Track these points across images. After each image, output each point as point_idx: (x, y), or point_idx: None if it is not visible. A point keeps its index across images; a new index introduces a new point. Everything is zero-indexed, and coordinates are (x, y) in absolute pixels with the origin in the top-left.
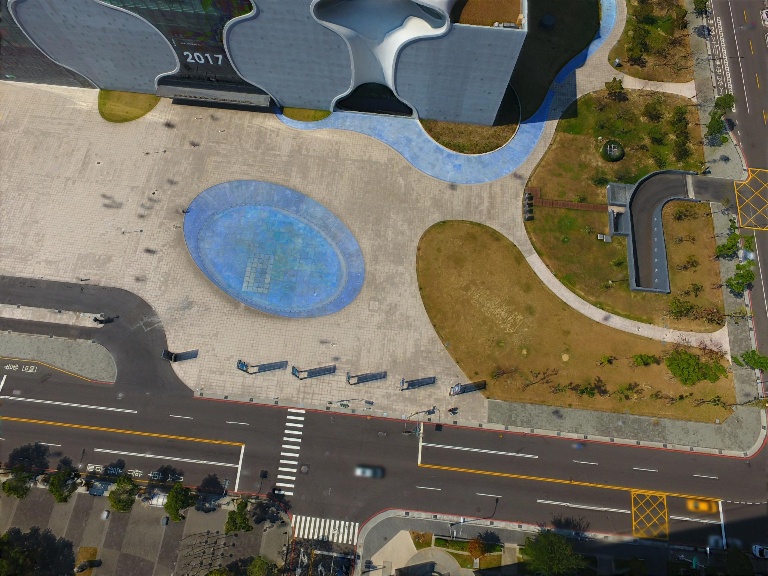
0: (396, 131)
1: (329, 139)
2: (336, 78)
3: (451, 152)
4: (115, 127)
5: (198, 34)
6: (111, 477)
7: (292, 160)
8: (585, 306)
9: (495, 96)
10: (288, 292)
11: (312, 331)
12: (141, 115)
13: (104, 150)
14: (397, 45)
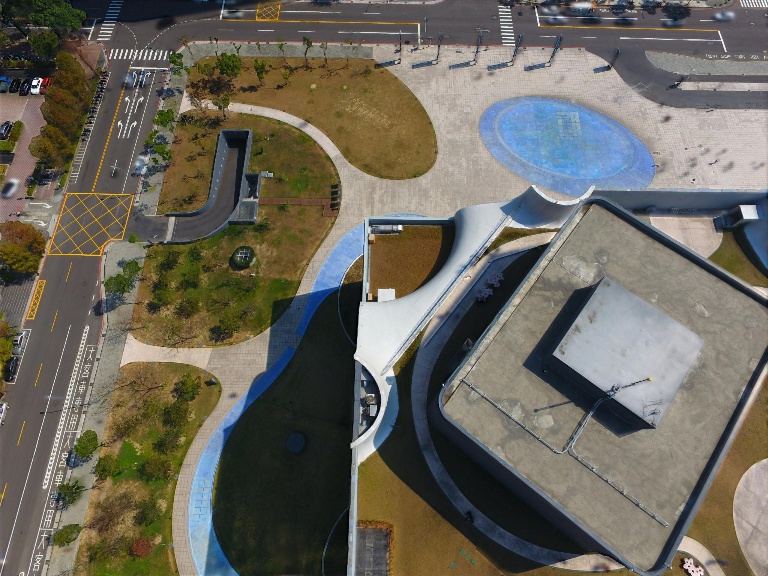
0: None
1: None
2: None
3: None
4: None
5: None
6: (618, 8)
7: None
8: (293, 122)
9: None
10: (540, 114)
11: (512, 89)
12: None
13: None
14: None
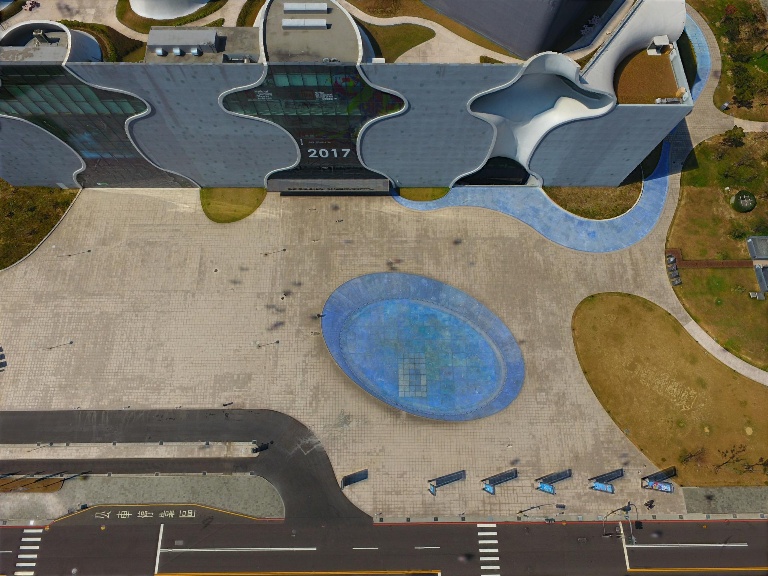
0: (521, 202)
1: (454, 218)
2: (468, 159)
3: (582, 219)
4: (225, 228)
5: (332, 133)
6: None
7: (421, 245)
8: (755, 372)
9: (633, 162)
10: (448, 392)
11: (483, 433)
12: (250, 212)
13: (219, 255)
14: (548, 127)
